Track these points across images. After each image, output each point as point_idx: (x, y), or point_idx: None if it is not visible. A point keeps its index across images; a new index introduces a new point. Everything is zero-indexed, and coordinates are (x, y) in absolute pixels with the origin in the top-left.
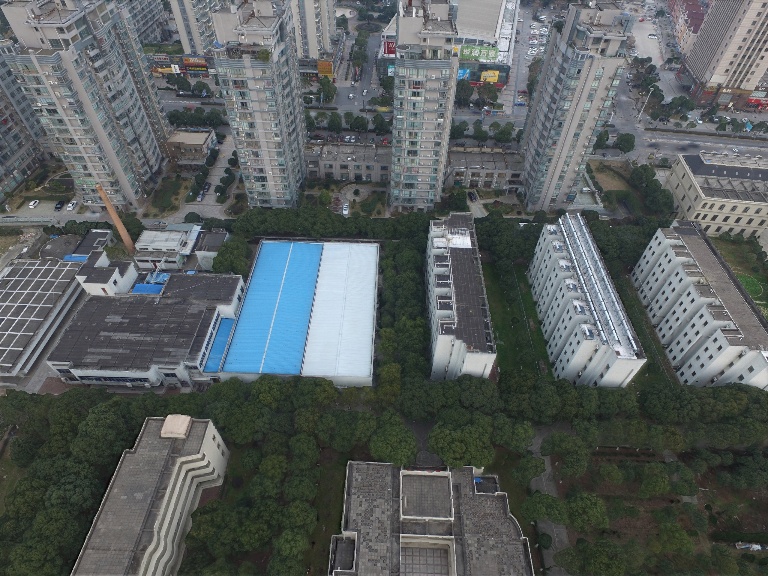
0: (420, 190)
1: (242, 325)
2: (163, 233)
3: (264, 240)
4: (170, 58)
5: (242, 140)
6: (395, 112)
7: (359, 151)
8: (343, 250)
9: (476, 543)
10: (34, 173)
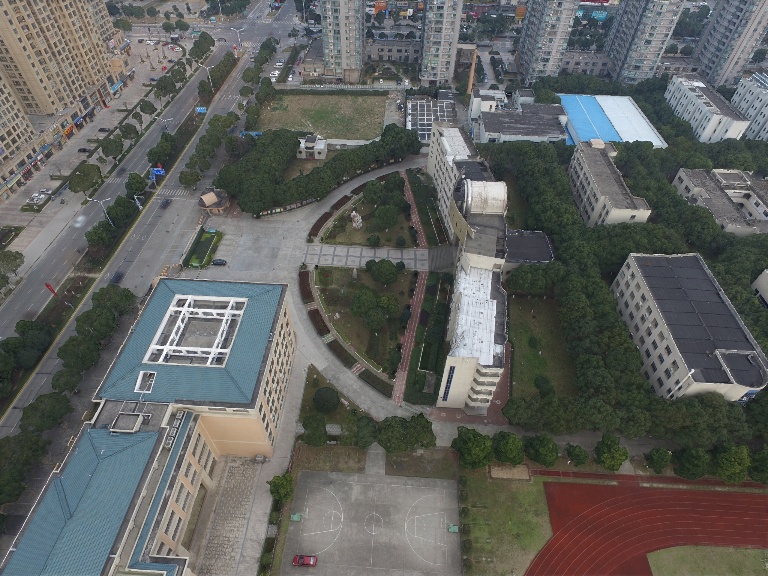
0: (643, 71)
1: (575, 126)
2: (490, 90)
3: (557, 93)
4: (409, 4)
5: (547, 30)
6: (647, 12)
7: (584, 54)
8: (609, 99)
9: (764, 193)
10: (363, 67)
